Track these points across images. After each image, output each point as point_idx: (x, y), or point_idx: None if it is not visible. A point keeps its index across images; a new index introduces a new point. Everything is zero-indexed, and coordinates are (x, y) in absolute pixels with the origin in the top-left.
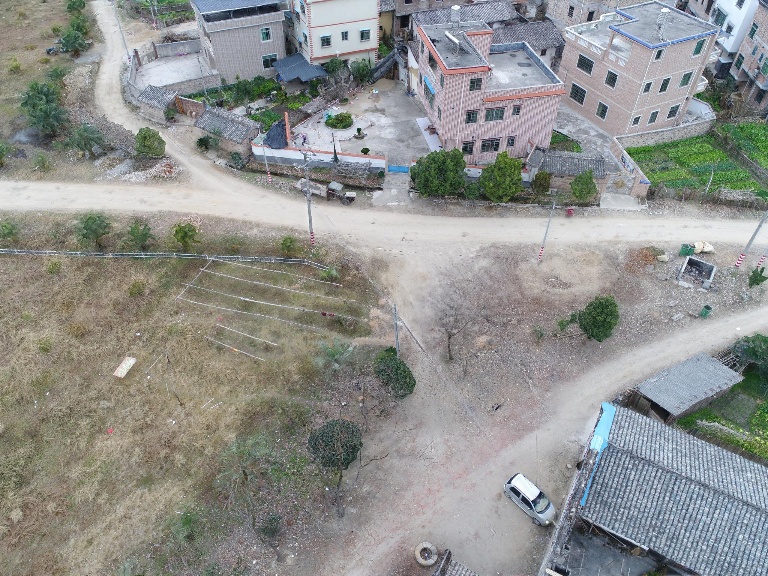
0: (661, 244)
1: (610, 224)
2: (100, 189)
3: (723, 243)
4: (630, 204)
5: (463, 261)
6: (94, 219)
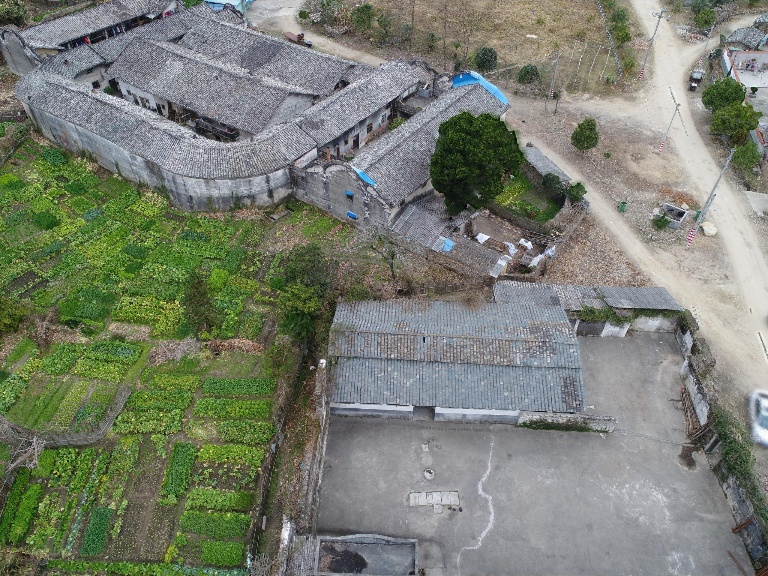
0: (707, 212)
1: (723, 192)
2: (664, 25)
3: (724, 245)
4: (760, 207)
5: (645, 125)
6: (621, 12)
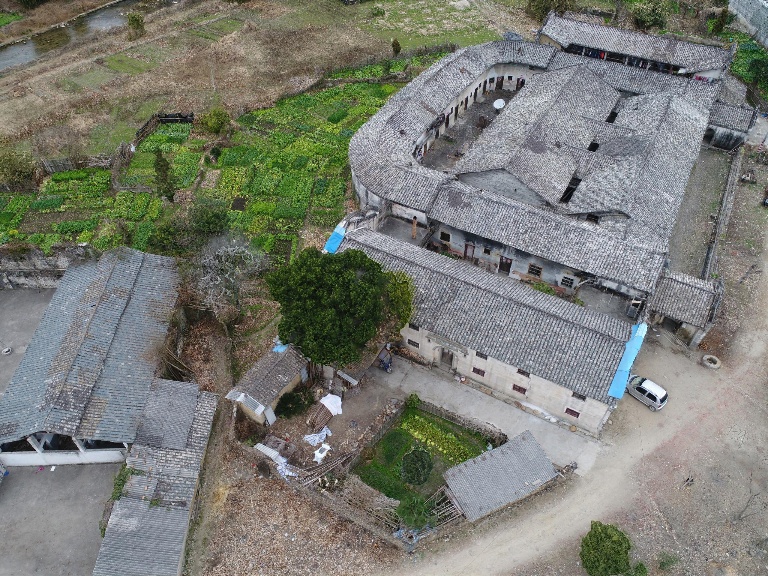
0: None
1: None
2: None
3: None
4: None
5: None
6: None
